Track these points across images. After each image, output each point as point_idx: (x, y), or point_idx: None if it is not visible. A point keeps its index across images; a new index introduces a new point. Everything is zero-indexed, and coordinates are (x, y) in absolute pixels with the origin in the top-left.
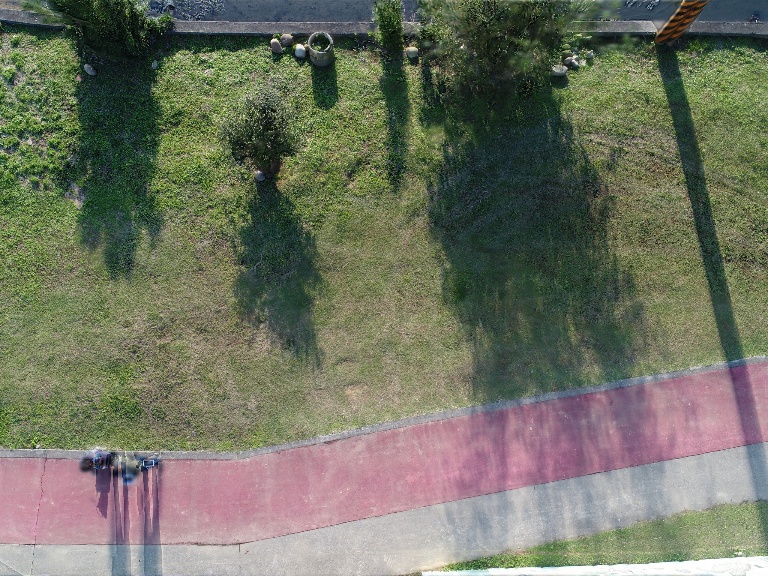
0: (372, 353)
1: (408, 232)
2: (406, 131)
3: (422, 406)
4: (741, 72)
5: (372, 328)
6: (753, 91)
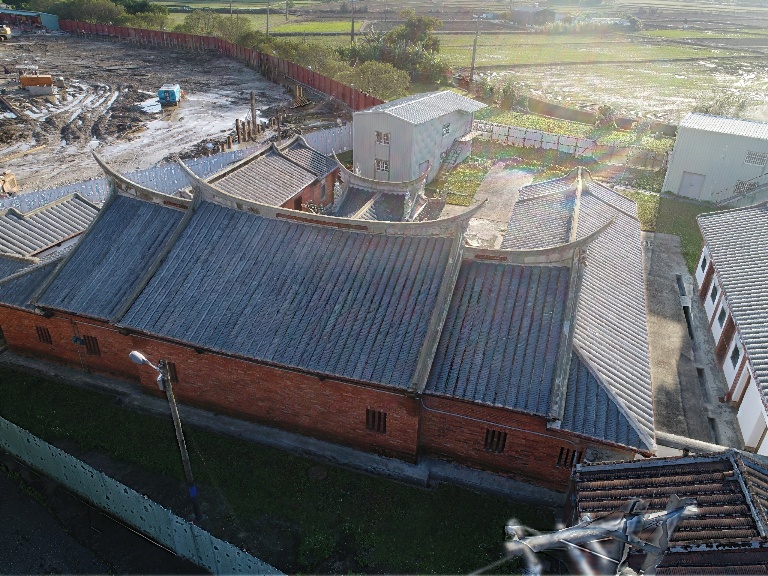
0: None
1: None
2: None
3: None
4: None
5: None
6: None
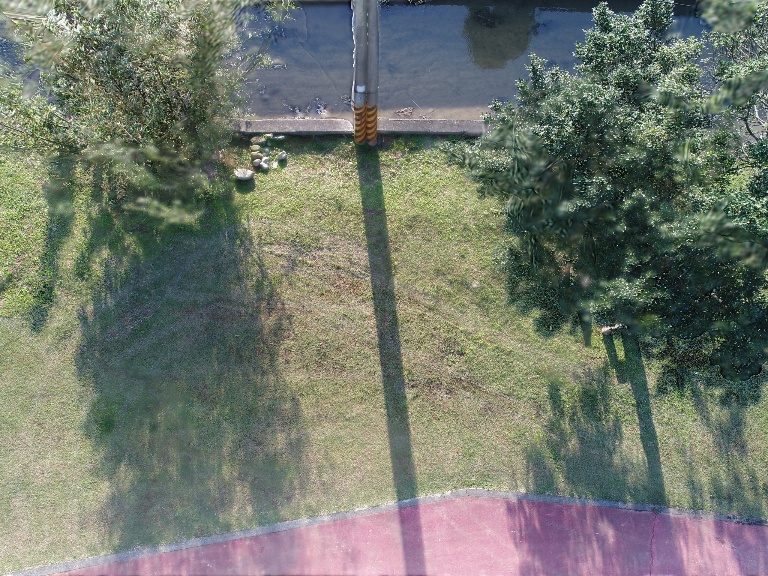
0: (0, 495)
1: (56, 357)
2: (66, 243)
3: (49, 555)
4: (449, 174)
5: (4, 466)
6: (458, 196)
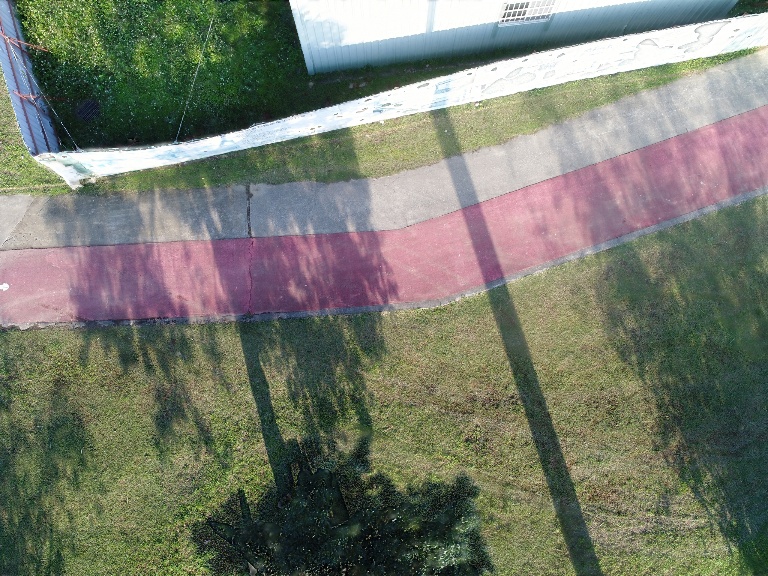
0: None
1: None
2: None
3: None
4: None
5: None
6: None
